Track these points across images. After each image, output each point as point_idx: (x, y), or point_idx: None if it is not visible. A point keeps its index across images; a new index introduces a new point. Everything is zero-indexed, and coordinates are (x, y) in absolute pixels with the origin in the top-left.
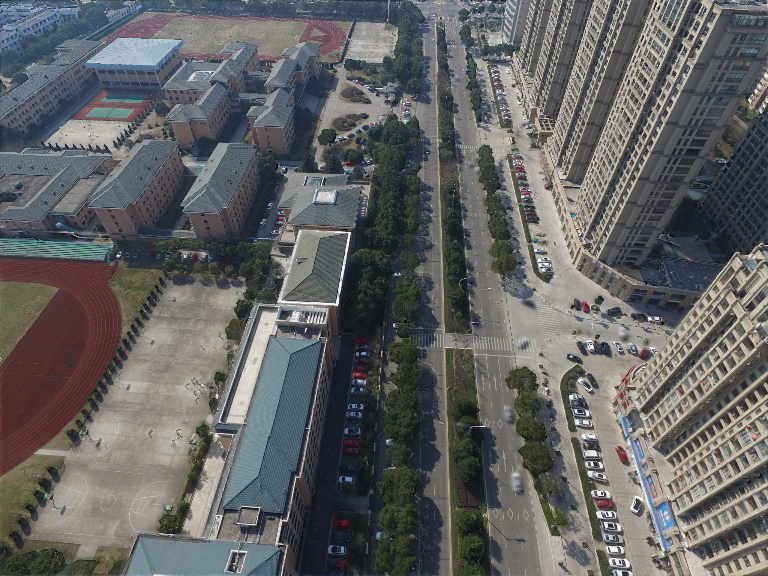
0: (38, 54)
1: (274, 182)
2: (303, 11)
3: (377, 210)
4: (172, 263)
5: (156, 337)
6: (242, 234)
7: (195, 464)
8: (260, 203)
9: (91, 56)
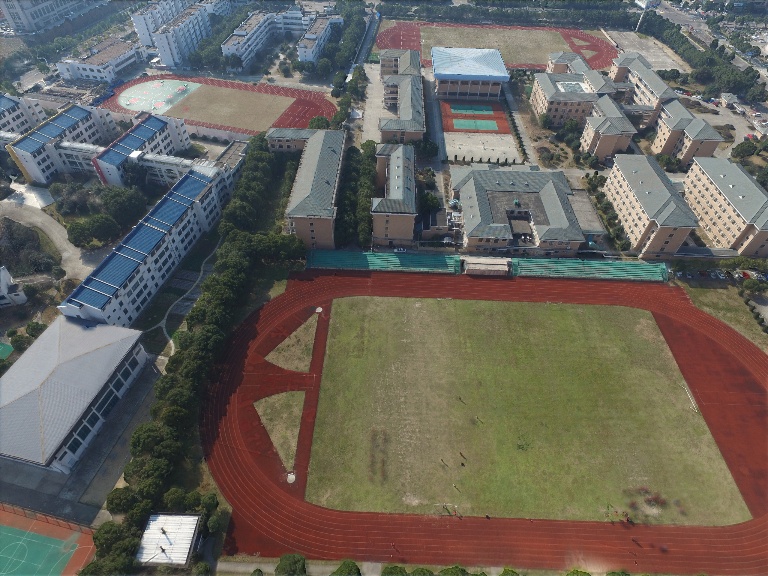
0: (346, 63)
1: None
2: (539, 19)
3: None
4: None
5: None
6: None
7: None
8: None
9: None
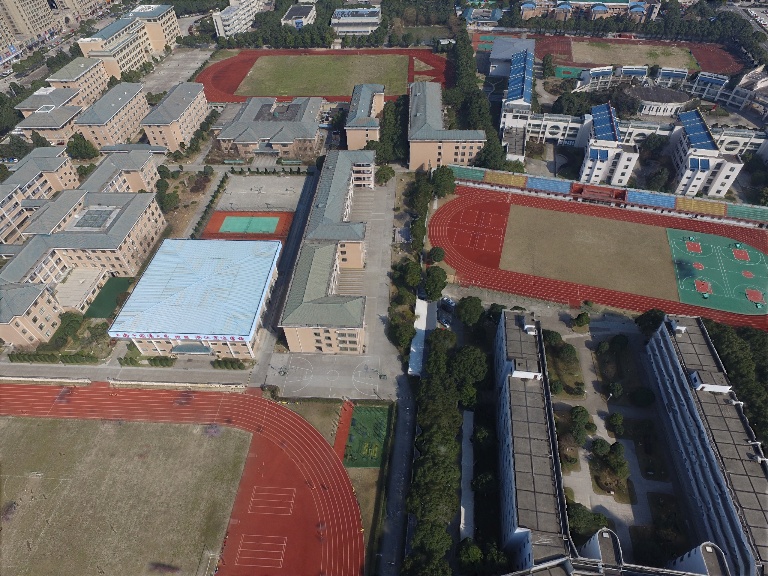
0: None
1: None
2: None
3: None
4: None
5: None
6: None
7: None
8: None
9: None
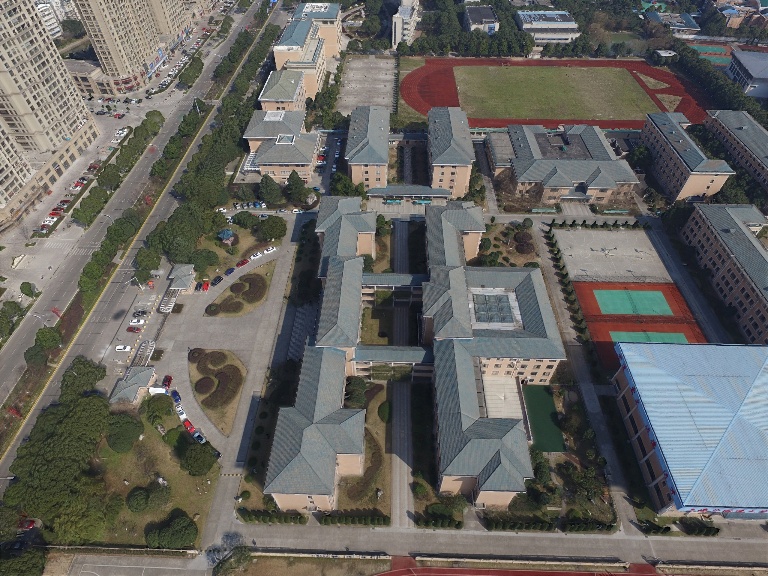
0: None
1: None
2: None
3: None
4: None
5: (383, 100)
6: None
7: None
8: (345, 172)
9: None
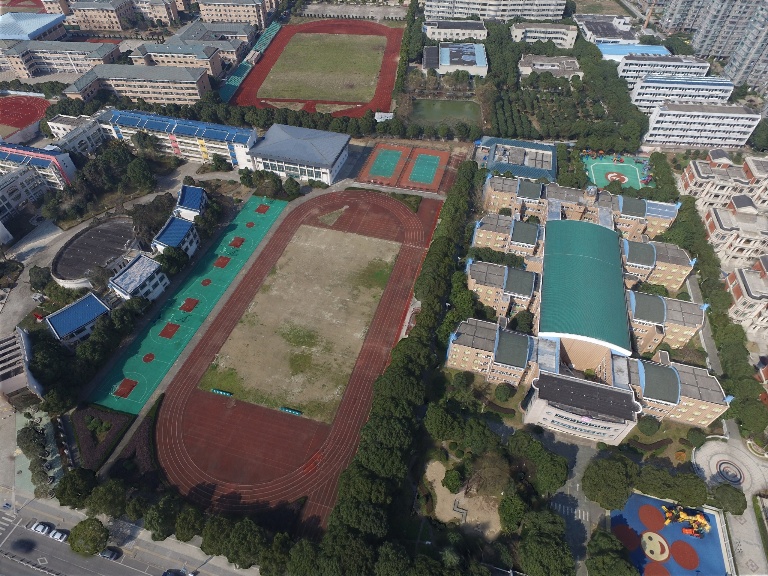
0: None
1: None
2: None
3: None
4: None
5: None
6: None
7: (383, 5)
8: None
9: None
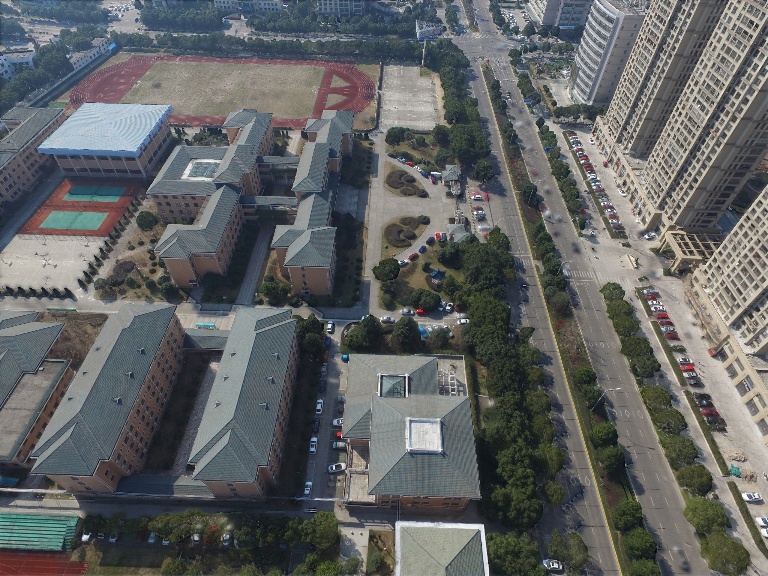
0: None
1: (320, 357)
2: None
3: (498, 438)
4: (177, 573)
5: None
6: (283, 472)
7: None
8: (303, 399)
9: (48, 131)
